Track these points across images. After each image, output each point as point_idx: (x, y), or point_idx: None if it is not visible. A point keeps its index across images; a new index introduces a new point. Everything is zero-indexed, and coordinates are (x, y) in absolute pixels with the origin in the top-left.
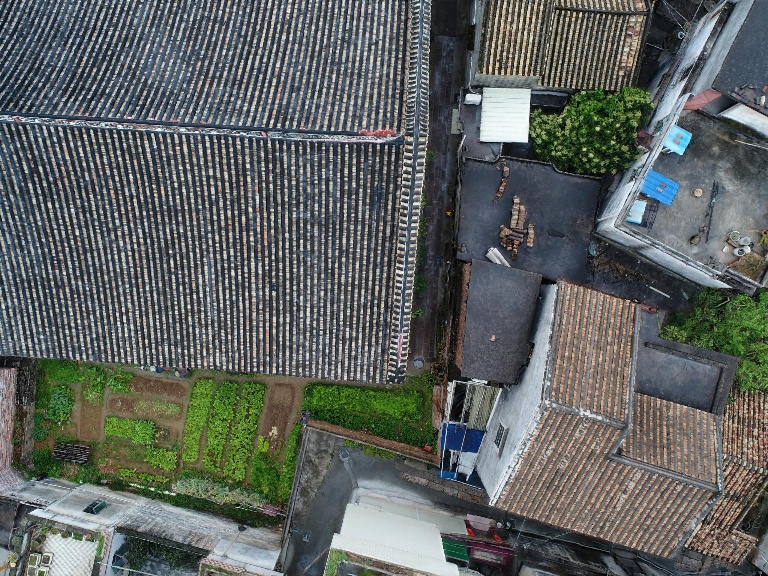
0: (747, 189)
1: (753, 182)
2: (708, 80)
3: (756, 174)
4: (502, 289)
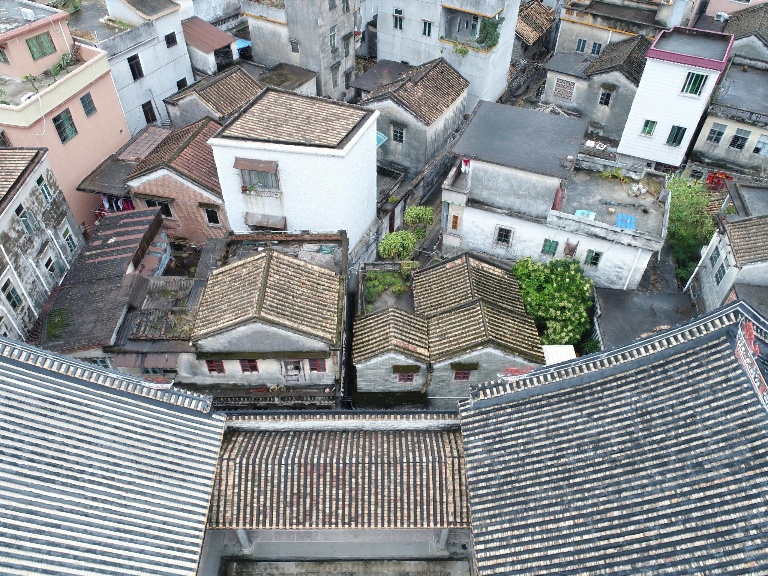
0: (596, 190)
1: (589, 188)
2: (544, 197)
3: (583, 187)
4: (763, 308)
